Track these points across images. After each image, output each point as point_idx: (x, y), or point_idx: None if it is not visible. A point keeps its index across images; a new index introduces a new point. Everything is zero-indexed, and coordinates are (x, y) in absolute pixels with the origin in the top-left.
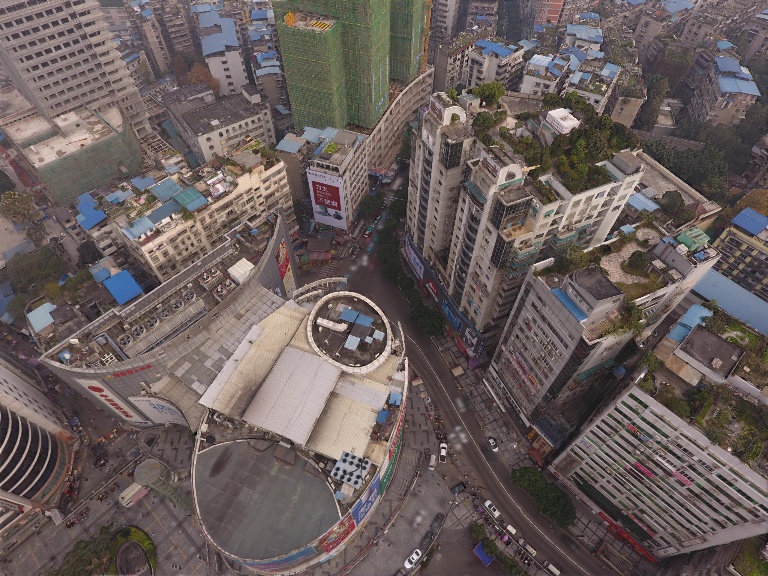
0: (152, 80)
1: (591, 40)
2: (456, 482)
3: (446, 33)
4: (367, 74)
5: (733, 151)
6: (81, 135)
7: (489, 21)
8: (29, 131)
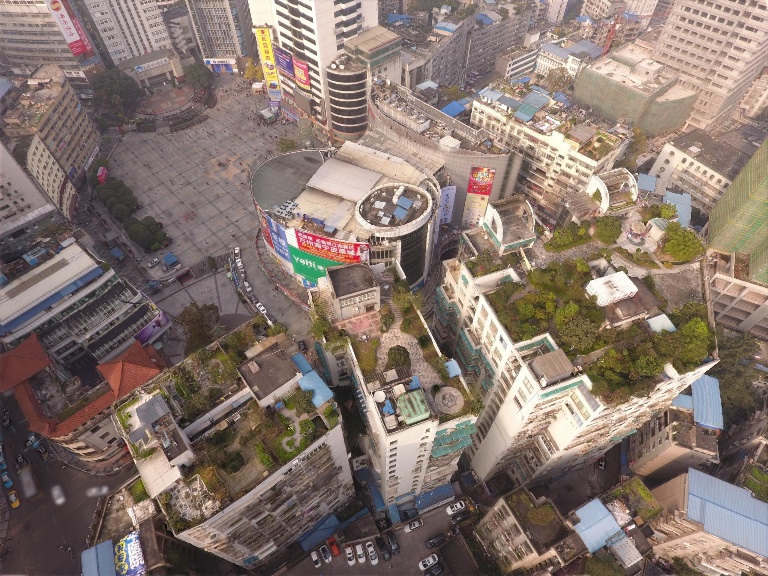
0: None
1: None
2: (308, 346)
3: None
4: None
5: None
6: (638, 79)
7: None
8: (633, 56)
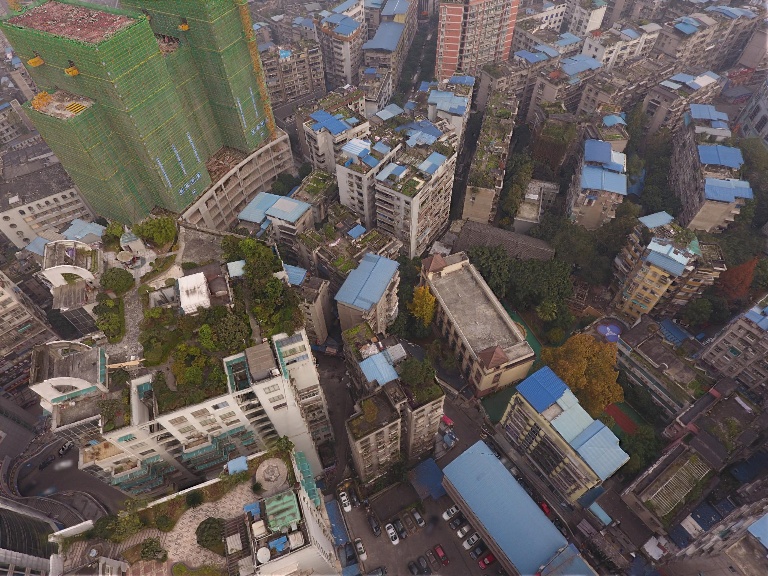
0: (31, 129)
1: (451, 112)
2: None
3: (346, 83)
4: (148, 160)
5: (588, 263)
6: None
7: (376, 75)
8: None
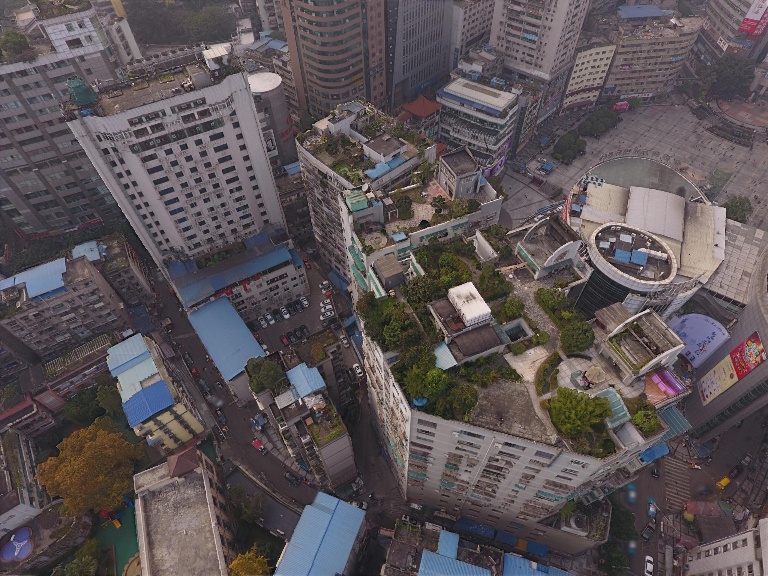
0: None
1: None
2: None
3: None
4: None
5: None
6: None
7: None
8: None
